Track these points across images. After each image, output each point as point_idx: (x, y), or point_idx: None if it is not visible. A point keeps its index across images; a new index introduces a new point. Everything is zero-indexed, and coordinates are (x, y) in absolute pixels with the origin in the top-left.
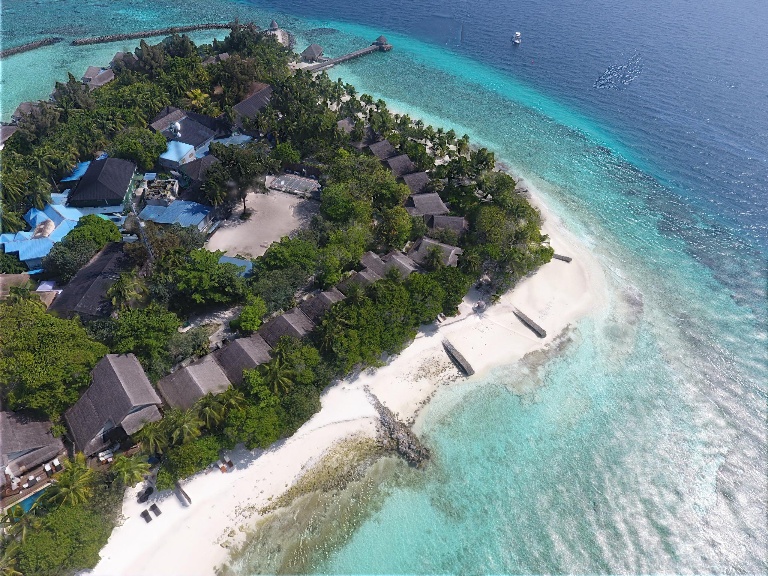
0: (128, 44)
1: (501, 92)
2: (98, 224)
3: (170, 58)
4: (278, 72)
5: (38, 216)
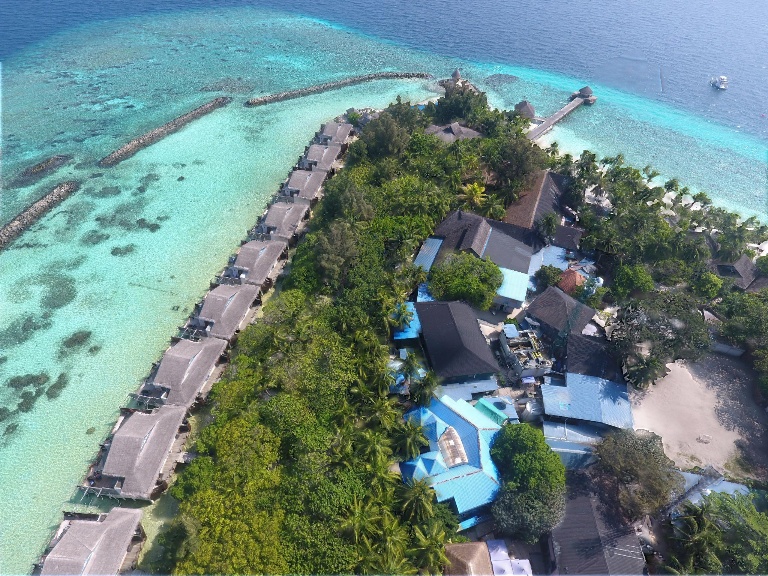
0: (306, 103)
1: (762, 159)
2: (542, 444)
3: (407, 134)
4: (540, 151)
5: (438, 423)
